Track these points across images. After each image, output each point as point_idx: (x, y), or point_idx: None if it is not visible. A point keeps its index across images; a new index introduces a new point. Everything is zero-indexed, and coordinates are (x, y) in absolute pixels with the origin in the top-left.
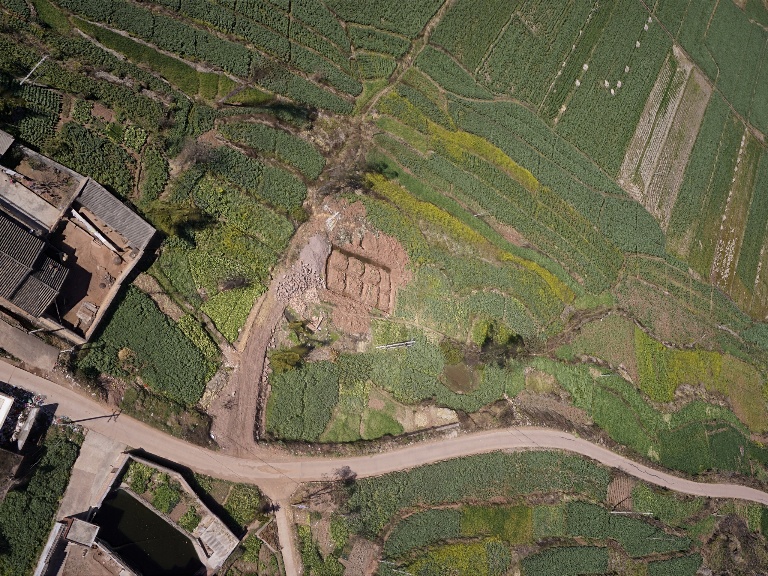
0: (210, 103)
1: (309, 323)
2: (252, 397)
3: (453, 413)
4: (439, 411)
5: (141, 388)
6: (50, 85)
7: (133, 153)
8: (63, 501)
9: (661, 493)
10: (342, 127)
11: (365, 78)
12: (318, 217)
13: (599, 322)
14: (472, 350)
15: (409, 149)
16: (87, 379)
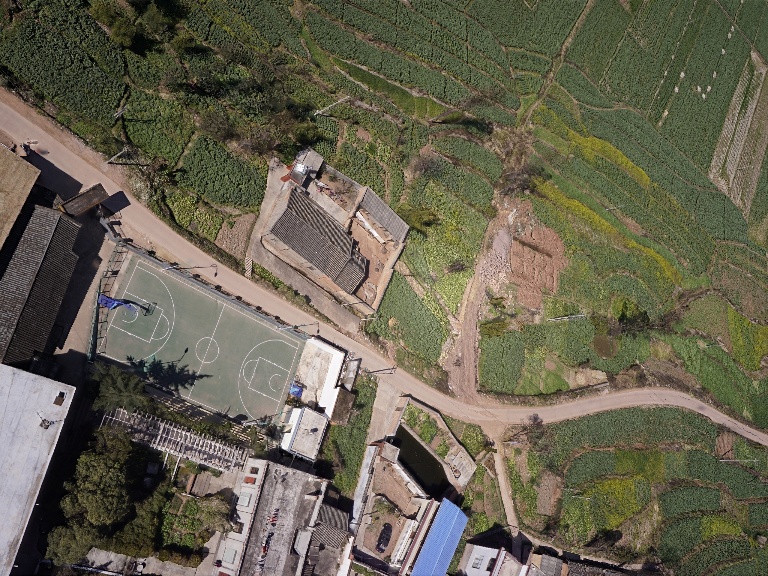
0: (423, 122)
1: (503, 300)
2: (471, 357)
3: (604, 374)
4: (593, 372)
5: (404, 349)
6: (331, 114)
7: (383, 165)
8: (369, 430)
9: (756, 447)
10: (510, 137)
11: (521, 94)
12: (502, 213)
13: (701, 300)
14: (612, 323)
15: (557, 154)
16: (377, 341)
